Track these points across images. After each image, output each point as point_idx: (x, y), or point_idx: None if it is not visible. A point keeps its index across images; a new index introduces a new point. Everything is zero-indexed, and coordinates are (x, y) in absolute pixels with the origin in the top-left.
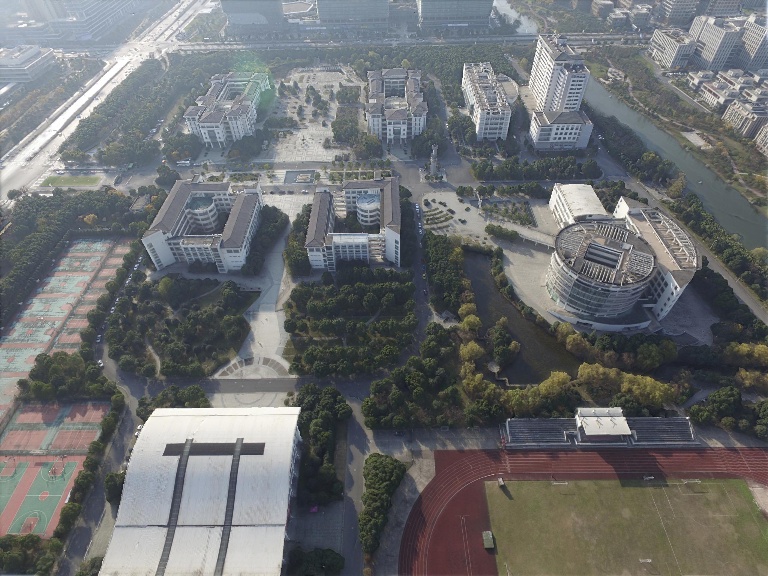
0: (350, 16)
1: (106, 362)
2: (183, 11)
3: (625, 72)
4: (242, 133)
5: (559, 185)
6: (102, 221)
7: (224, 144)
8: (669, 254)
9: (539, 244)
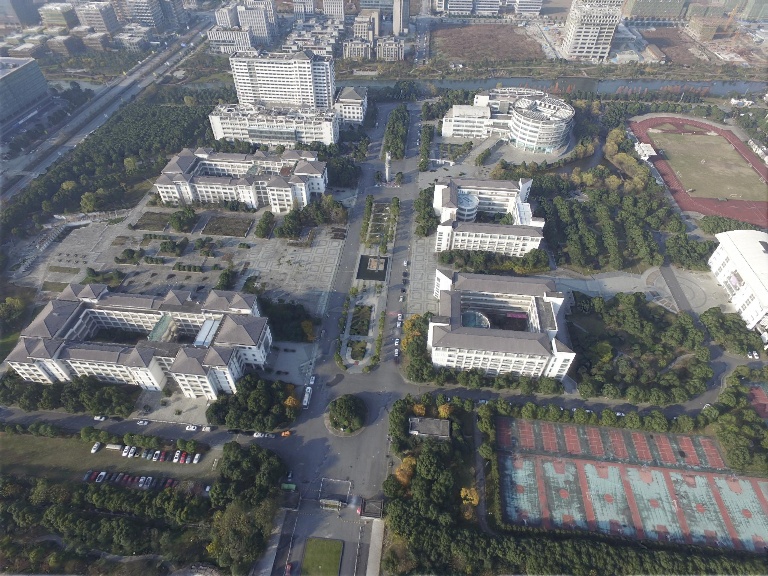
0: None
1: (702, 403)
2: None
3: None
4: None
5: (446, 117)
6: None
7: (271, 344)
8: None
9: None
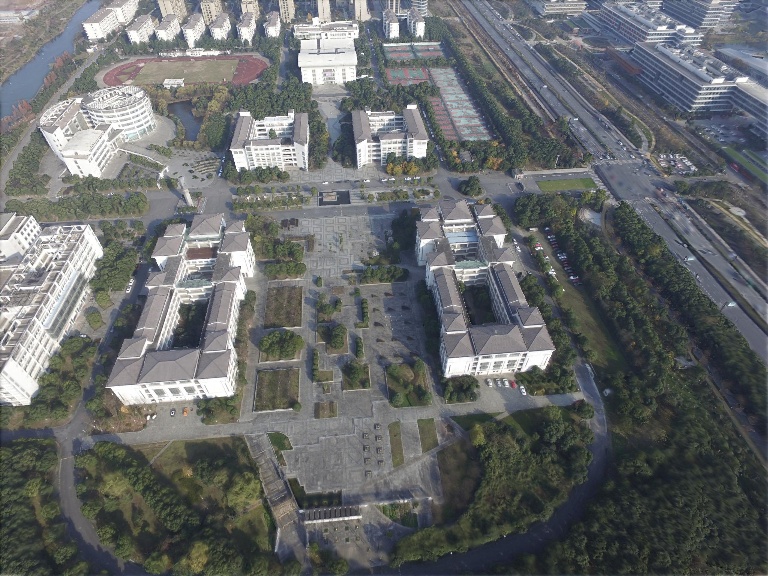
0: None
1: None
2: None
3: None
4: None
5: None
6: None
7: None
8: None
9: None
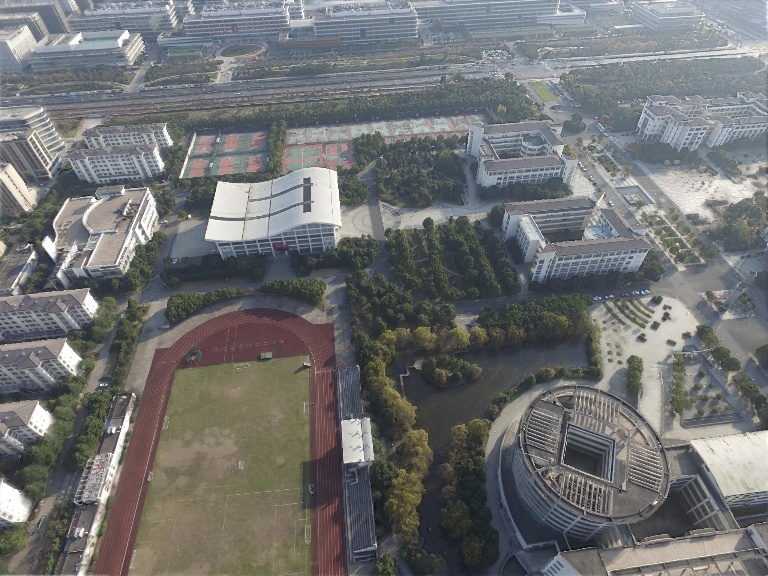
0: None
1: None
2: None
3: None
4: (671, 140)
5: None
6: (506, 116)
7: (647, 138)
8: (649, 567)
9: None
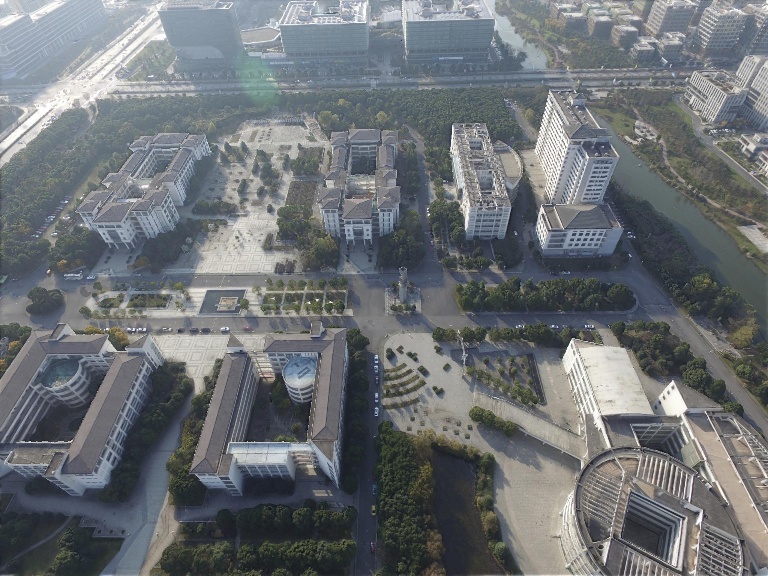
0: (321, 49)
1: None
2: (134, 37)
3: (657, 127)
4: (157, 229)
5: (578, 342)
6: None
7: (132, 245)
8: (760, 518)
9: (548, 444)
